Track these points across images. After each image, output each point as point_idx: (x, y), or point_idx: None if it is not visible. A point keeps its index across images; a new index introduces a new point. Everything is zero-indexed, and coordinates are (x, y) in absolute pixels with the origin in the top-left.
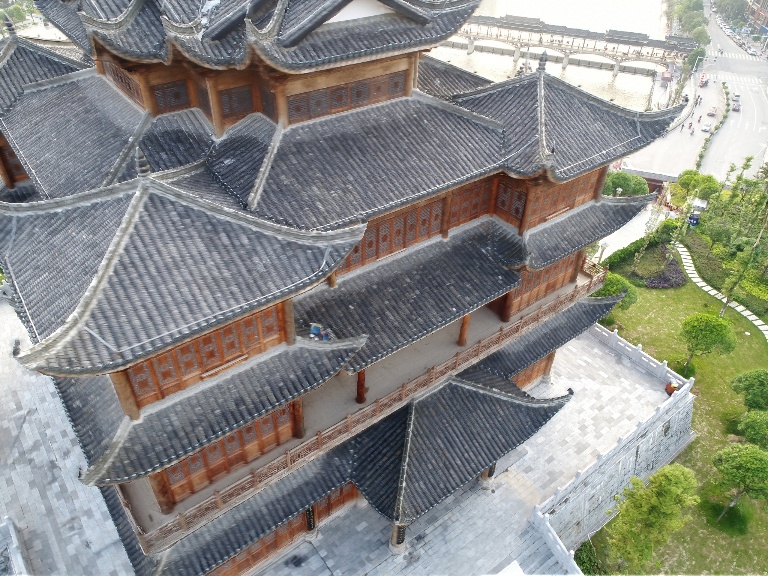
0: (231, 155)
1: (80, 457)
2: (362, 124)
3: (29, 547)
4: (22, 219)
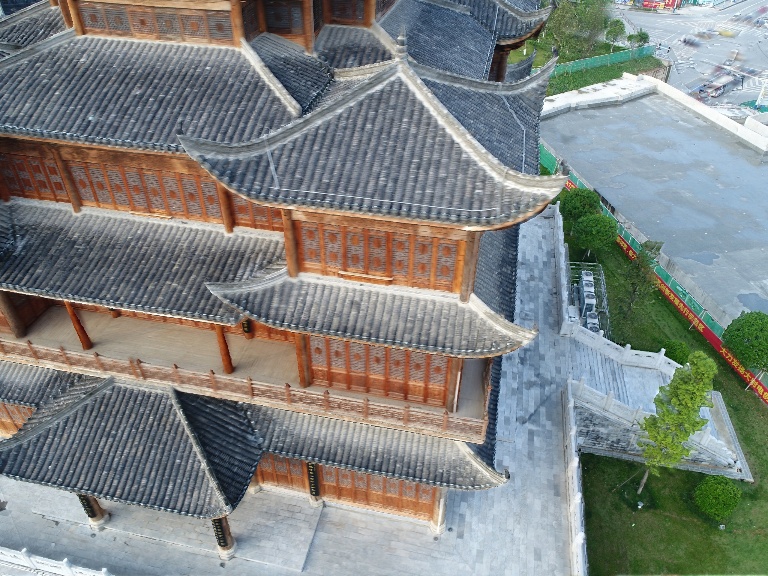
0: None
1: None
2: None
3: (557, 322)
4: None
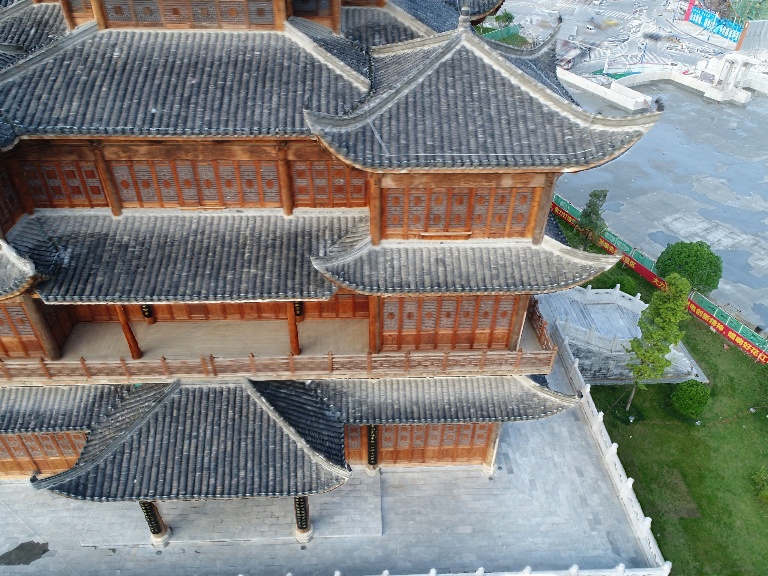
0: None
1: None
2: None
3: None
4: None
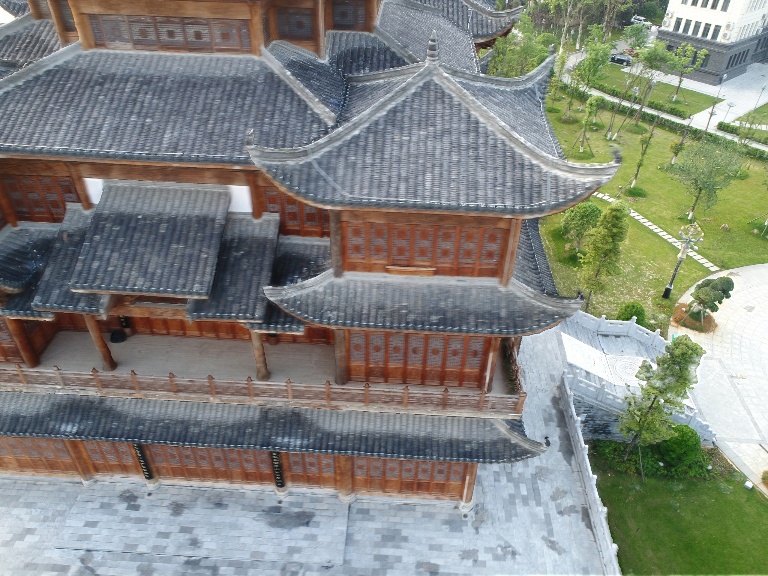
0: (358, 67)
1: (213, 532)
2: (396, 22)
3: None
4: (322, 159)
